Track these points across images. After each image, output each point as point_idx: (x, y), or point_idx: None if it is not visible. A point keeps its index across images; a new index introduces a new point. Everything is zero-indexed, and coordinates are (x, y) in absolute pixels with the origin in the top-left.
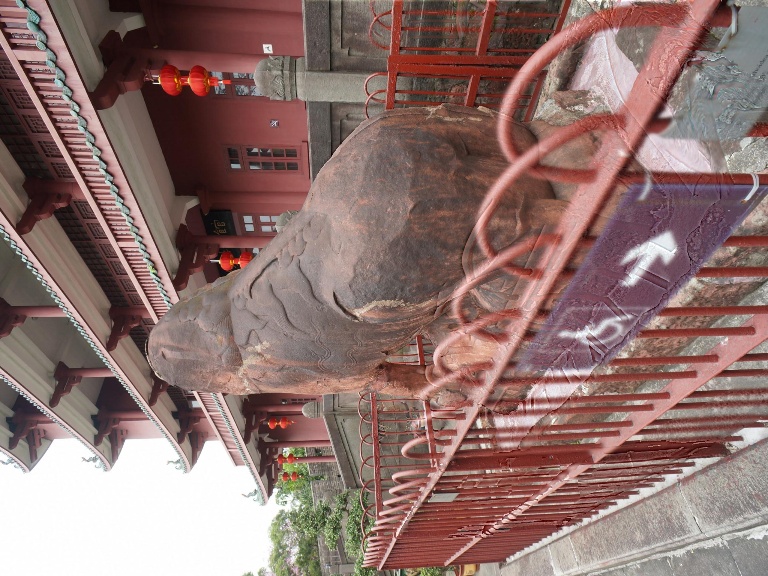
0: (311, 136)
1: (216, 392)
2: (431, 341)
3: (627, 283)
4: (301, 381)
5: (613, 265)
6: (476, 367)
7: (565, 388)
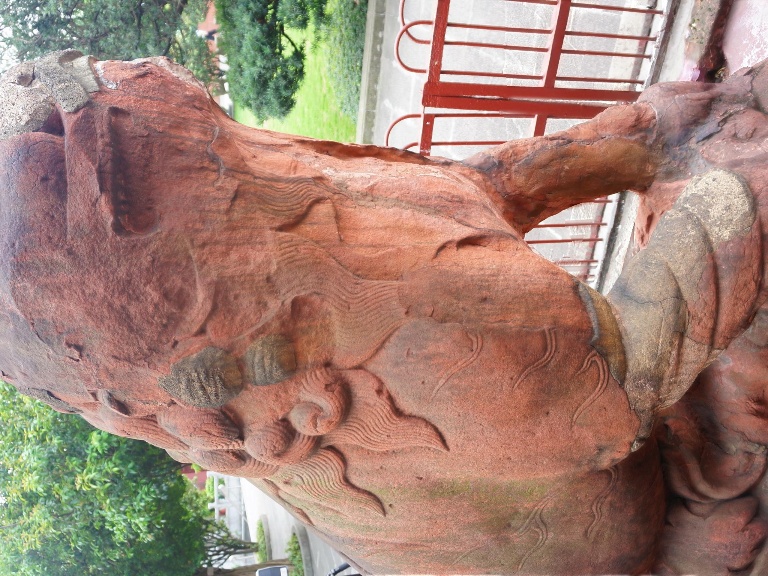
0: None
1: None
2: None
3: None
4: None
5: None
6: None
7: None
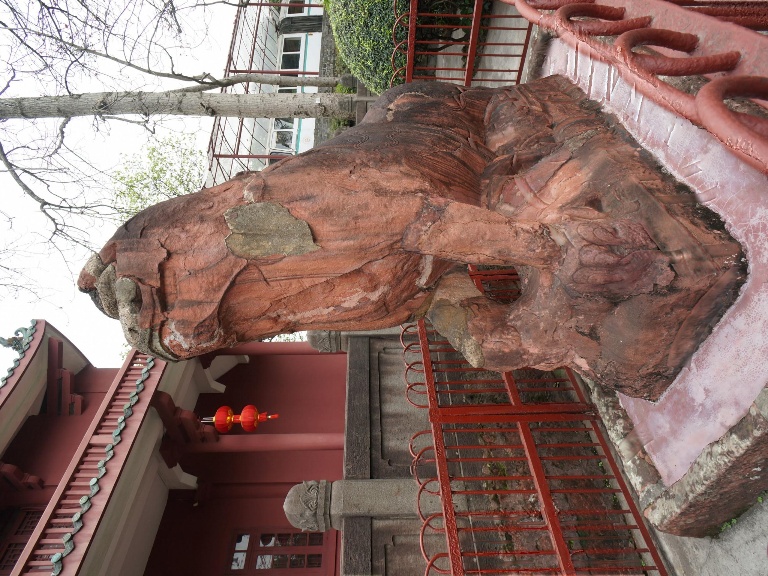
0: (350, 364)
1: (181, 229)
2: (536, 314)
3: (580, 79)
4: (329, 167)
5: (564, 88)
6: (578, 201)
7: (648, 101)
